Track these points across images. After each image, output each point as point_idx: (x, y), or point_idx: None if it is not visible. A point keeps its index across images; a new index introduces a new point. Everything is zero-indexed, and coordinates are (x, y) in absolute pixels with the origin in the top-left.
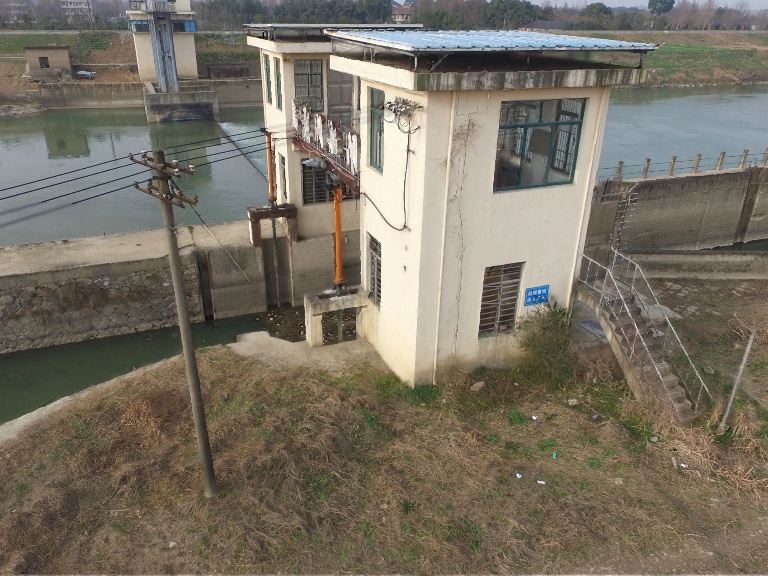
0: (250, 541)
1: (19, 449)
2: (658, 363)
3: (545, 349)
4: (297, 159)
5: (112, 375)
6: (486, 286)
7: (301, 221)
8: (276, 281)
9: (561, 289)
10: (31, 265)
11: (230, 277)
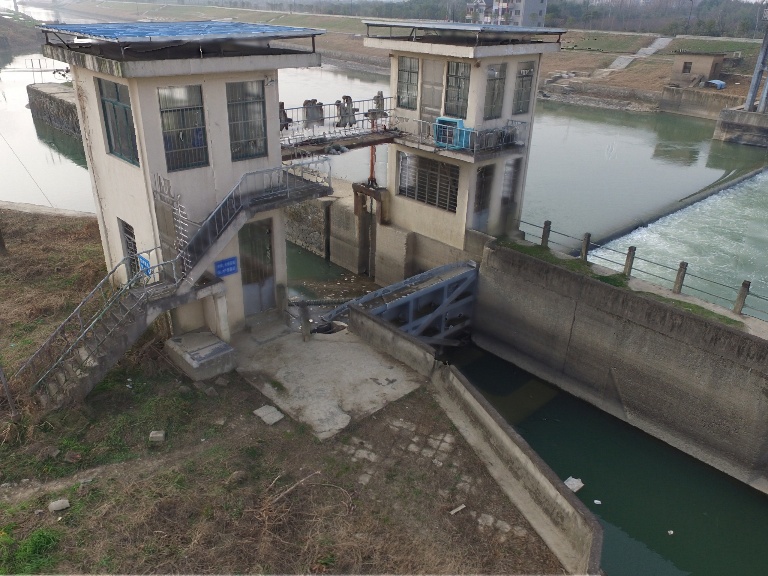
0: None
1: (66, 219)
2: (93, 359)
3: None
4: (395, 150)
5: None
6: (125, 235)
7: (393, 209)
8: (370, 253)
9: None
10: None
11: (340, 232)
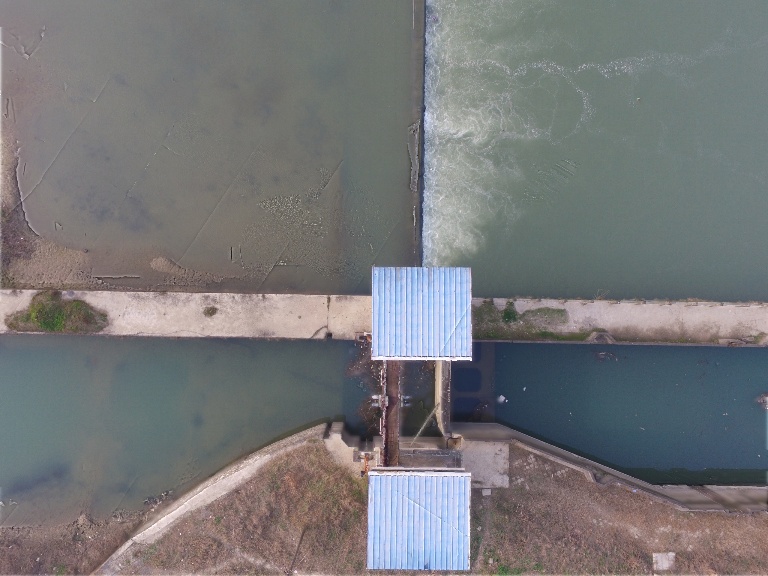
0: None
1: (257, 480)
2: None
3: None
4: None
5: None
6: None
7: None
8: None
9: None
10: (249, 327)
11: None
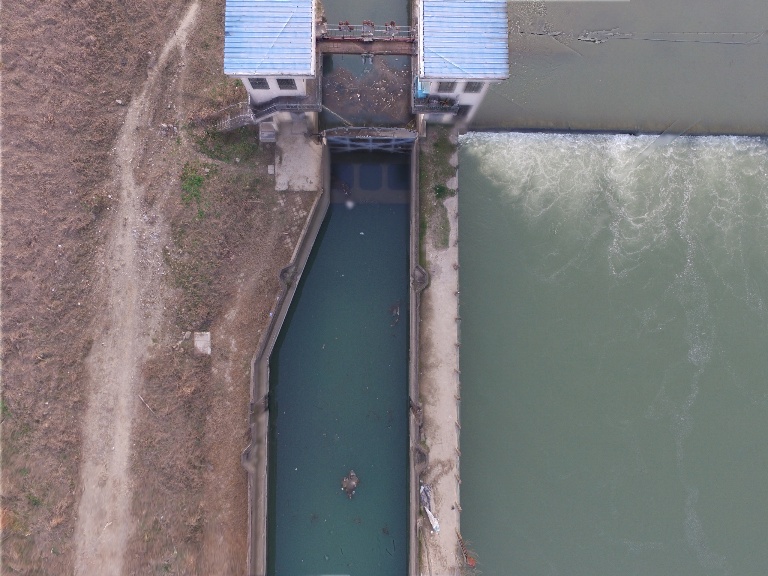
0: (222, 2)
1: None
2: None
3: None
4: None
5: None
6: None
7: None
8: None
9: None
10: None
11: None
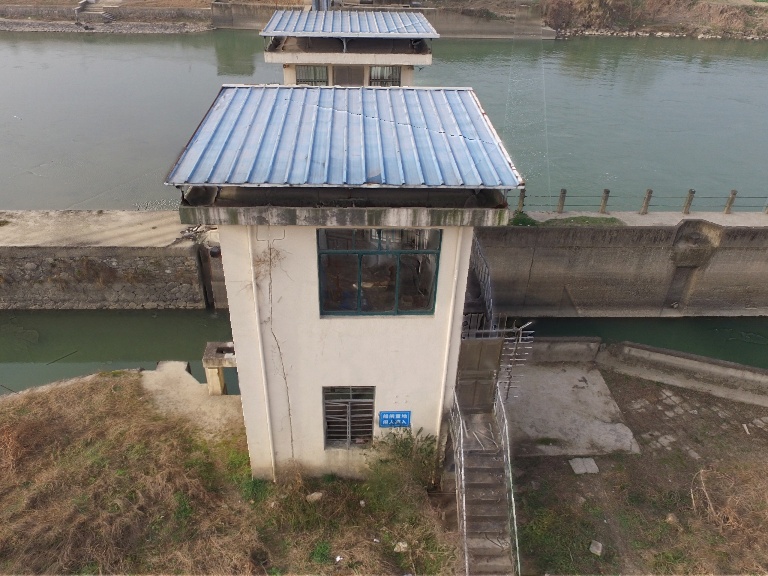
0: None
1: None
2: (499, 539)
3: (386, 481)
4: None
5: (124, 341)
6: (329, 402)
7: None
8: None
9: (428, 417)
10: (56, 237)
11: None
